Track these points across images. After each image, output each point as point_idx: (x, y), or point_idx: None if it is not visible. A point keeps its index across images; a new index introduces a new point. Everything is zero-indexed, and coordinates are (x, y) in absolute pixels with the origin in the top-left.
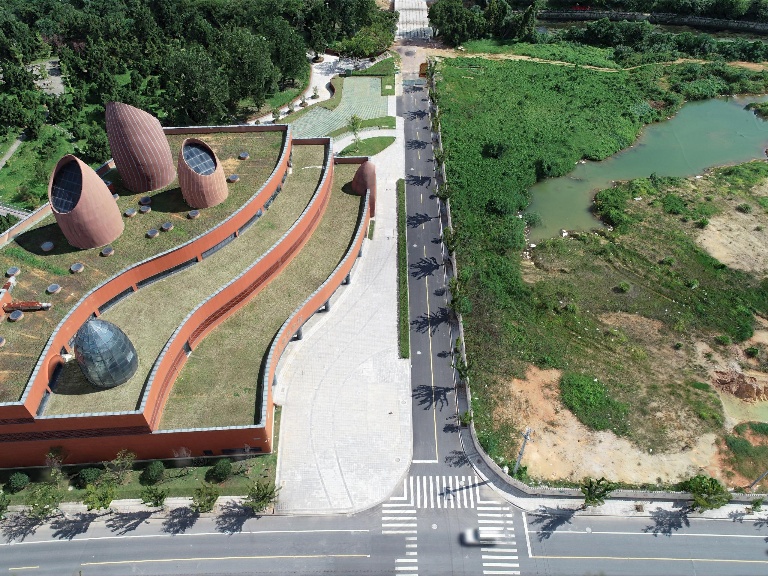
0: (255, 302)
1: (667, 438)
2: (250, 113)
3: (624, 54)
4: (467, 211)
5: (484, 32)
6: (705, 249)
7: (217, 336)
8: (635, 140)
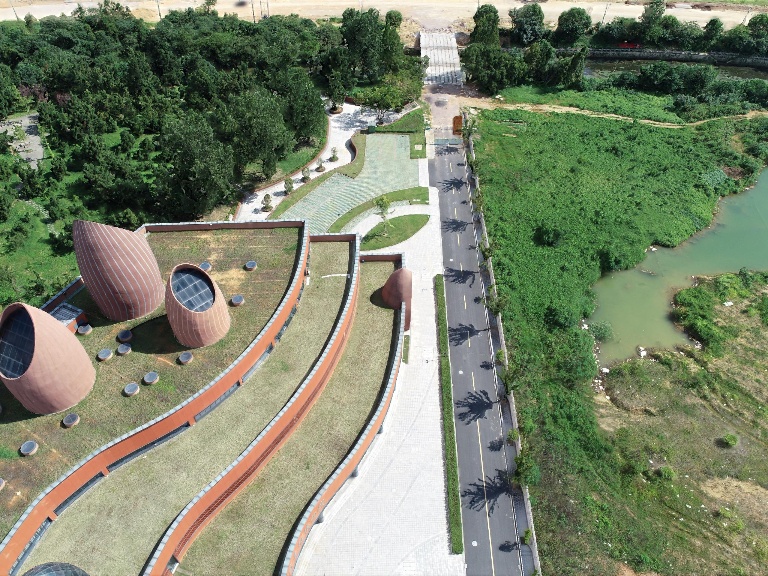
0: (263, 478)
1: None
2: (258, 181)
3: (687, 106)
4: (522, 322)
5: (523, 76)
6: None
7: (213, 536)
8: (712, 219)
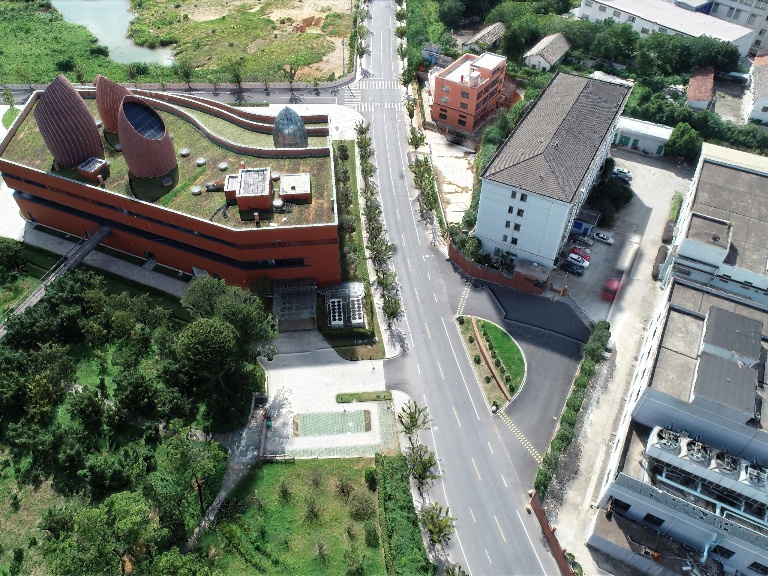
0: None
1: (327, 46)
2: None
3: None
4: (137, 81)
5: None
6: (207, 20)
7: None
8: None
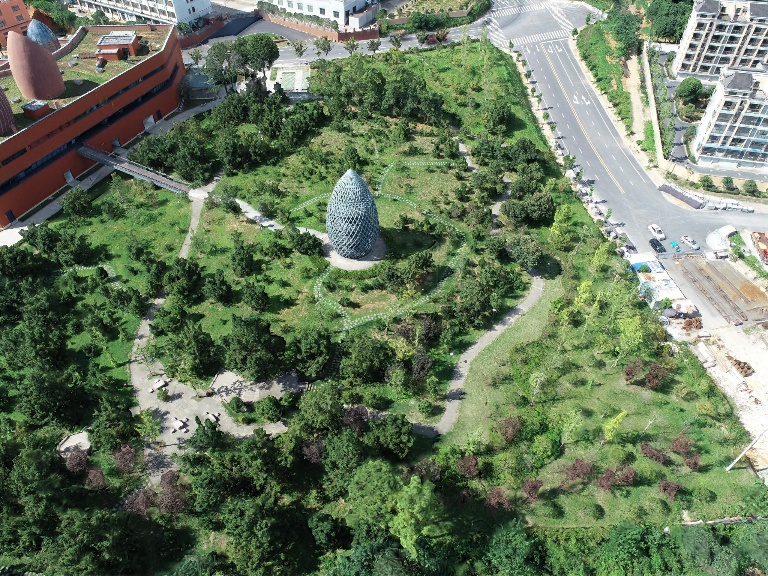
0: None
1: None
2: None
3: None
4: None
5: None
6: None
7: None
8: None
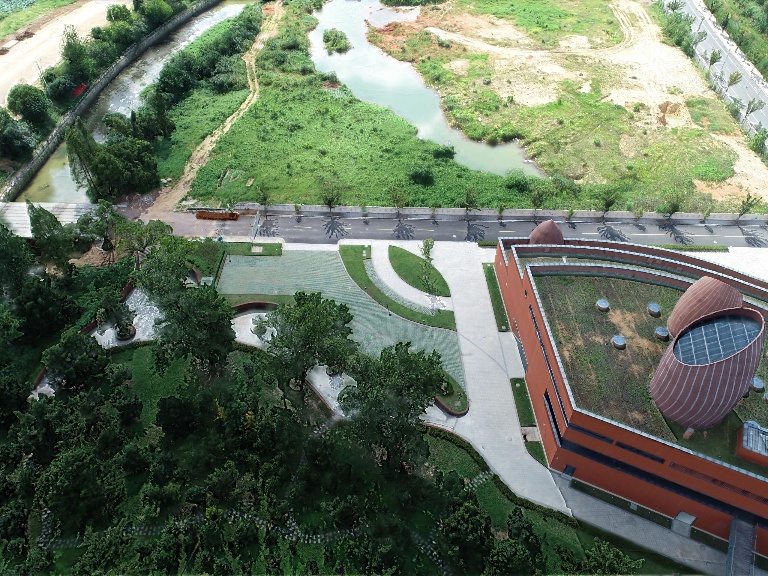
0: None
1: (724, 149)
2: (306, 407)
3: (229, 81)
4: (524, 203)
5: None
6: (539, 104)
7: None
8: None
